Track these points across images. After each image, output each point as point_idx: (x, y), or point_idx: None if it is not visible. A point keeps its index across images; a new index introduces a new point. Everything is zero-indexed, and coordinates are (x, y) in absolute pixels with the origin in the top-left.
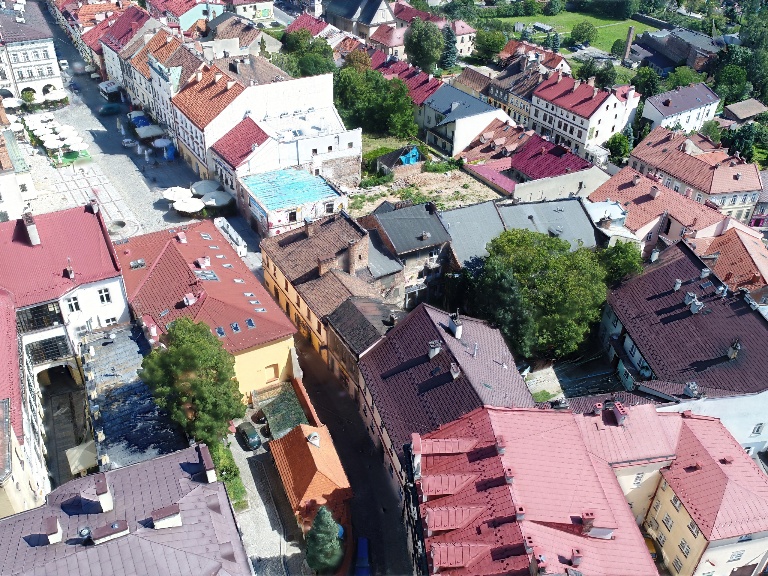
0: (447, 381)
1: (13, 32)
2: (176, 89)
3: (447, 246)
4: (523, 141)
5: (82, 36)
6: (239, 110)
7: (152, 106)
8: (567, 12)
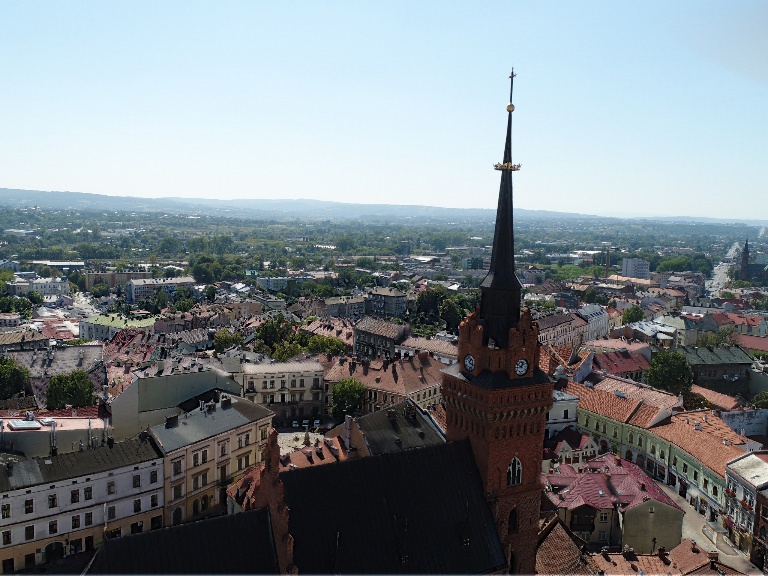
0: None
1: None
2: None
3: None
4: None
5: None
6: None
7: None
8: None
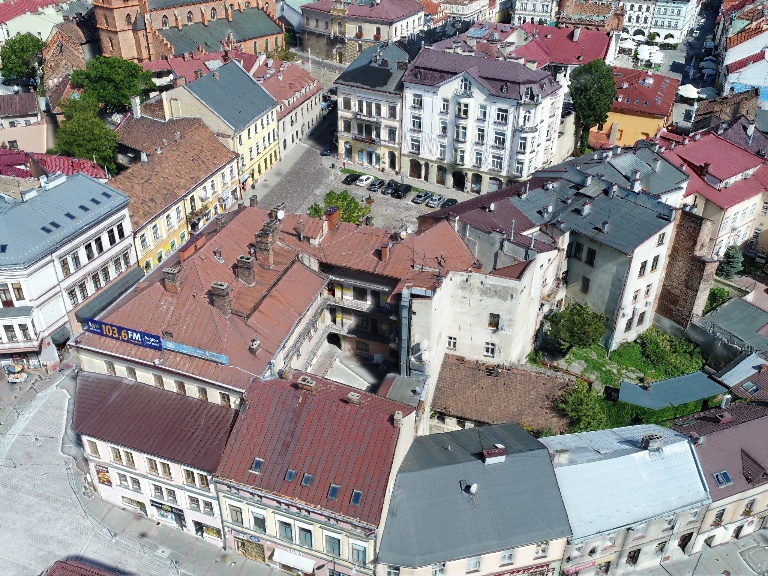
0: None
1: None
2: None
3: None
4: None
5: (719, 15)
6: (760, 44)
7: None
8: None
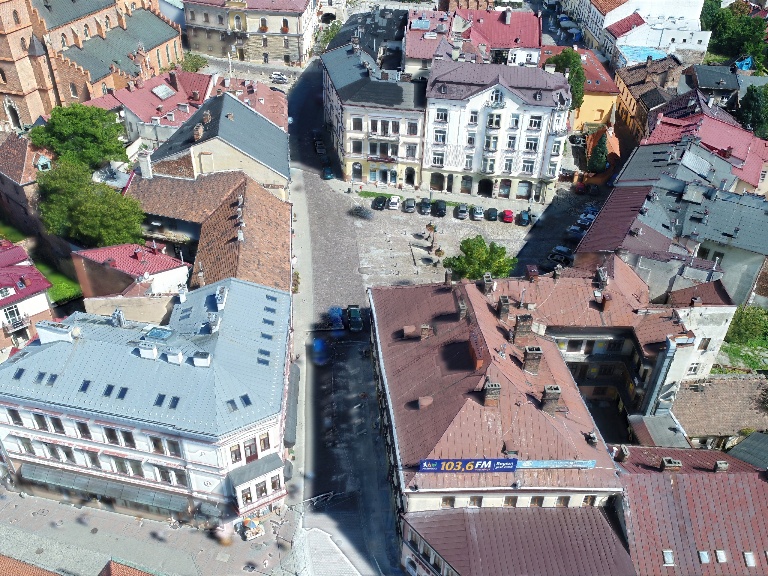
0: (691, 113)
1: None
2: None
3: (736, 94)
4: None
5: None
6: (632, 7)
7: (576, 10)
8: None
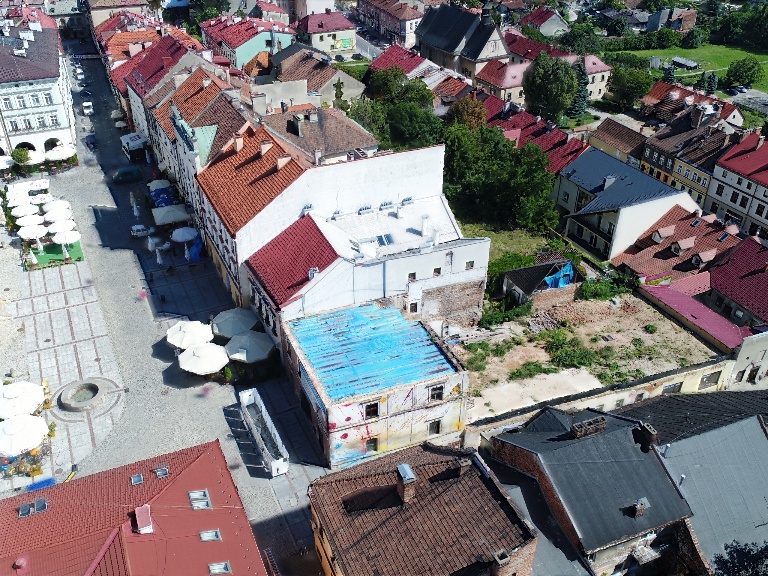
0: None
1: (6, 69)
2: (205, 160)
3: (678, 521)
4: (726, 246)
5: (111, 72)
6: (293, 204)
7: (178, 176)
8: (710, 44)
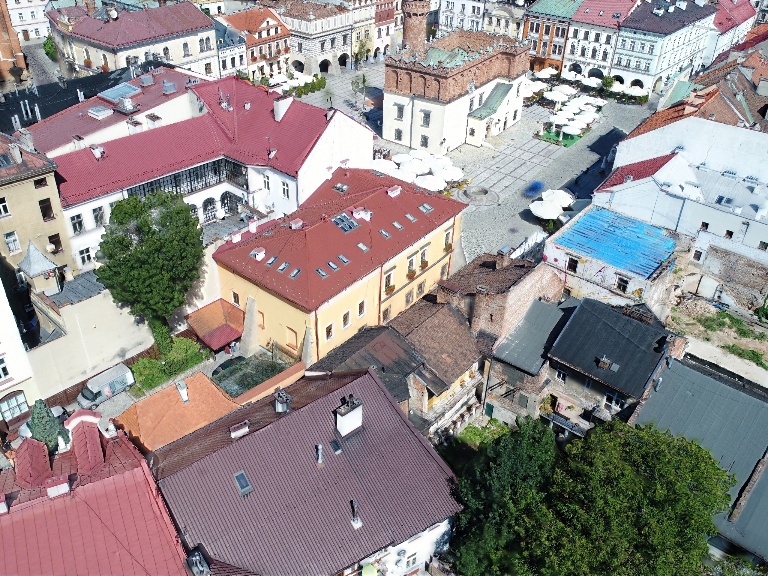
0: None
1: (638, 19)
2: None
3: (633, 404)
4: None
5: None
6: (670, 140)
7: None
8: None
